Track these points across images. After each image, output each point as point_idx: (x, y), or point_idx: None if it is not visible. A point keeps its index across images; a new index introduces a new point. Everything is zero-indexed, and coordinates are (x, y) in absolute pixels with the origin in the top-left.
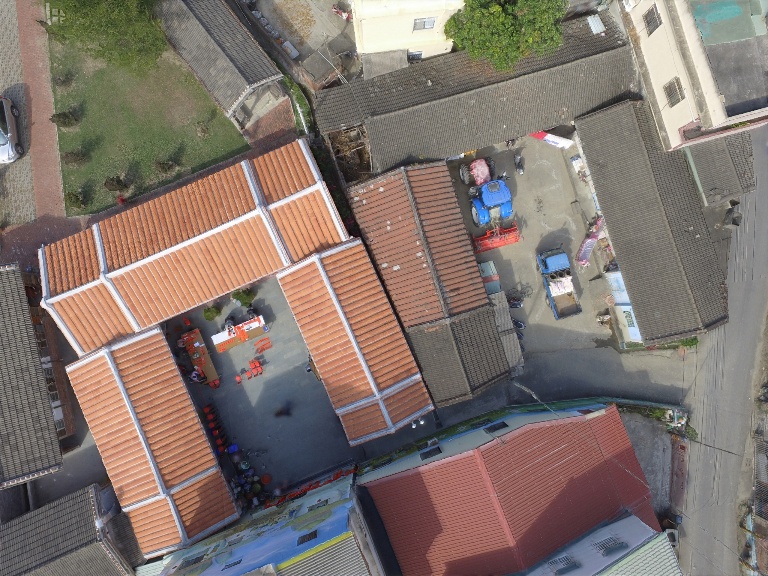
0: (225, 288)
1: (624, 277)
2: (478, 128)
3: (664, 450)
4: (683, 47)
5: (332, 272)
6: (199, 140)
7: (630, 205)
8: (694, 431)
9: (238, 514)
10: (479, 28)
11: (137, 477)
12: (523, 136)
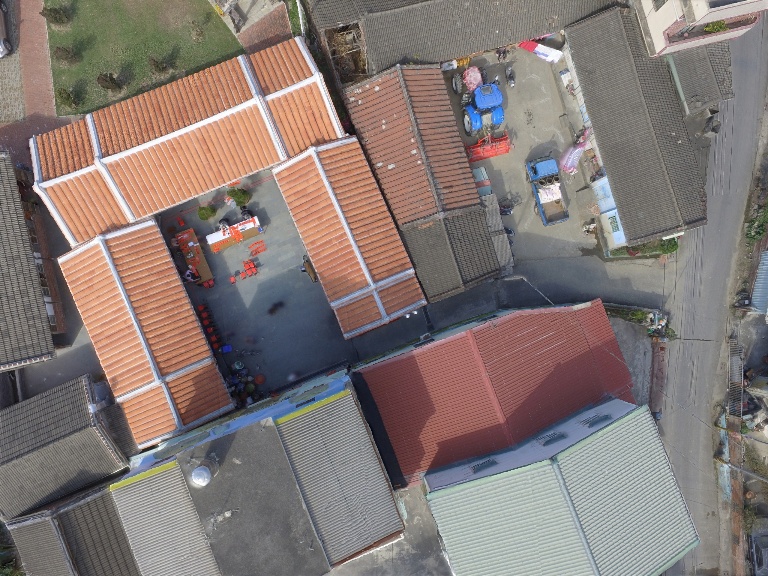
0: (221, 180)
1: (610, 180)
2: (471, 32)
3: (645, 353)
4: None
5: (328, 166)
6: (193, 43)
7: (616, 110)
8: (674, 332)
9: (233, 405)
10: None
11: (132, 366)
12: (514, 47)
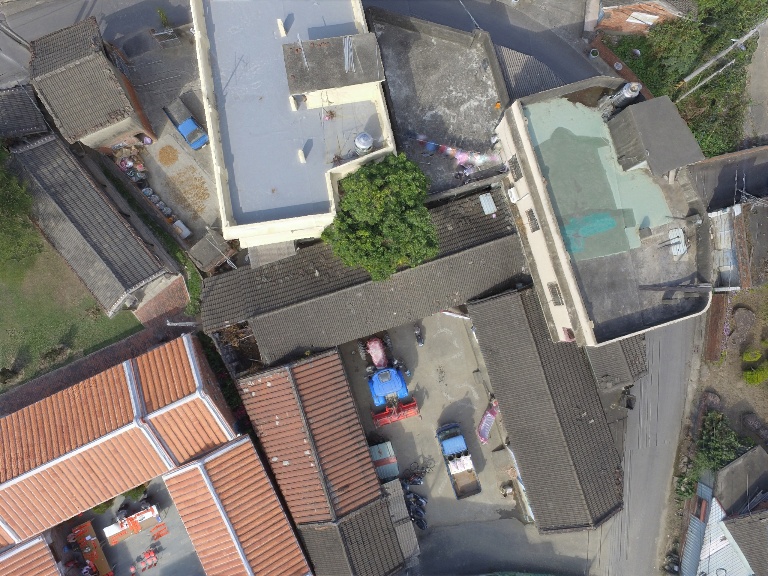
0: (108, 495)
1: (518, 464)
2: (367, 317)
3: None
4: (556, 263)
5: (217, 476)
6: (91, 321)
7: (521, 394)
8: None
9: None
10: (347, 251)
11: None
12: None
